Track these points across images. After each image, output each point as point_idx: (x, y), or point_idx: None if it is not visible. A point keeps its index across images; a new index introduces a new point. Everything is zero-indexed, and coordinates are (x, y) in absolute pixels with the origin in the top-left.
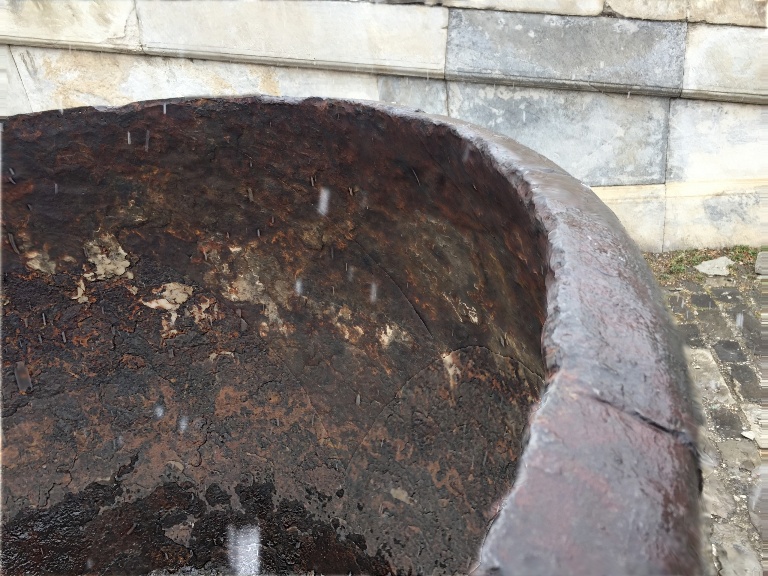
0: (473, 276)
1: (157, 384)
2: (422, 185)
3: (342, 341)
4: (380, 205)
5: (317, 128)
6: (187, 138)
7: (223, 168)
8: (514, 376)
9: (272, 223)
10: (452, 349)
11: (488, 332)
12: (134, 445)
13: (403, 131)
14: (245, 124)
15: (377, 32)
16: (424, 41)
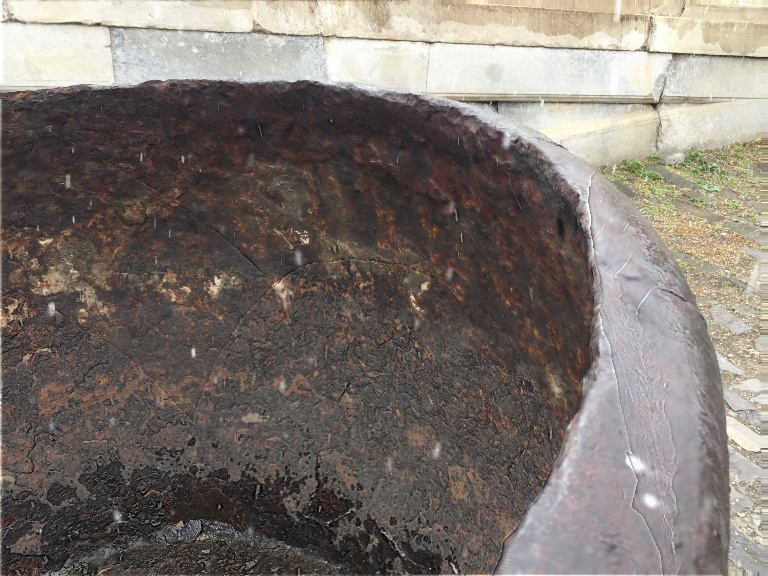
0: (308, 202)
1: None
2: (265, 137)
3: (169, 305)
4: (214, 165)
5: (155, 106)
6: (3, 132)
7: (40, 158)
8: (346, 273)
9: (90, 207)
10: (282, 276)
11: (319, 248)
12: None
13: (256, 93)
14: (72, 111)
15: (34, 52)
16: (88, 60)
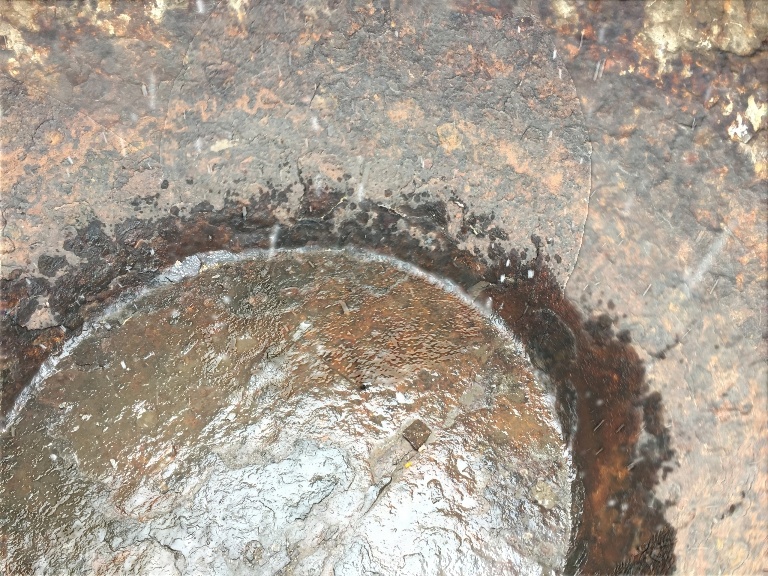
0: None
1: None
2: None
3: (107, 39)
4: None
5: None
6: None
7: None
8: None
9: None
10: None
11: None
12: None
13: None
14: None
15: None
16: None
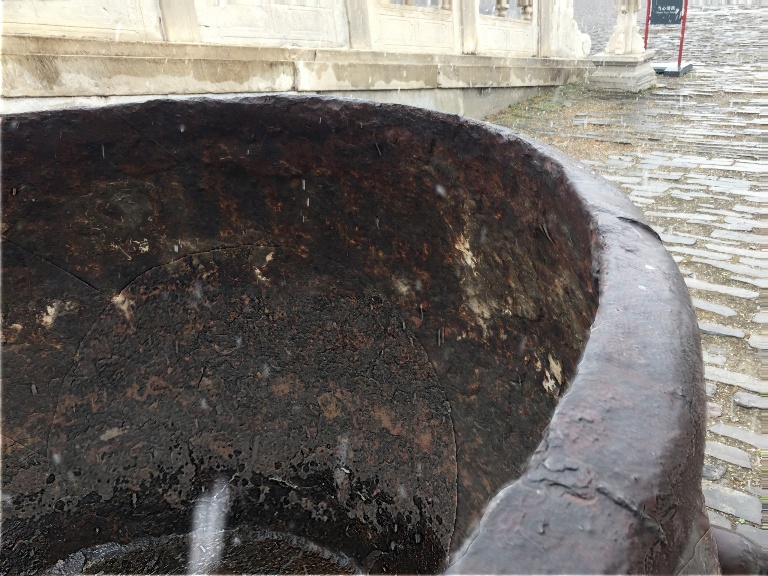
0: (149, 211)
1: None
2: (107, 156)
3: None
4: (48, 193)
5: None
6: None
7: None
8: (188, 269)
9: None
10: (120, 289)
11: (158, 252)
12: None
13: (103, 117)
14: None
15: None
16: None
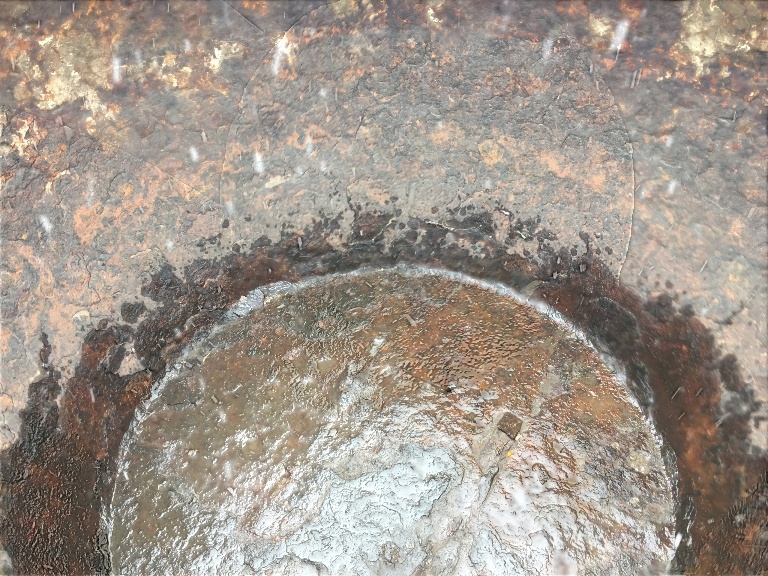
0: None
1: (13, 250)
2: None
3: (171, 92)
4: None
5: None
6: None
7: None
8: (356, 9)
9: None
10: (284, 31)
11: None
12: (33, 325)
13: None
14: None
15: None
16: None
